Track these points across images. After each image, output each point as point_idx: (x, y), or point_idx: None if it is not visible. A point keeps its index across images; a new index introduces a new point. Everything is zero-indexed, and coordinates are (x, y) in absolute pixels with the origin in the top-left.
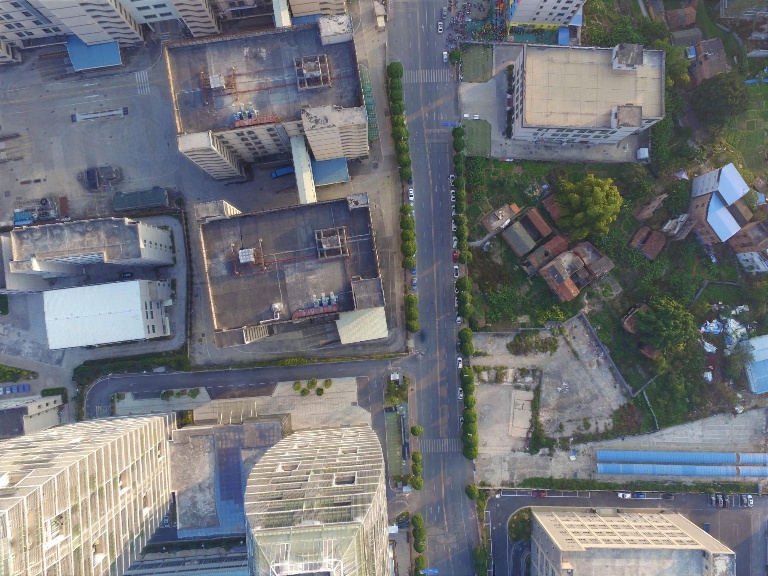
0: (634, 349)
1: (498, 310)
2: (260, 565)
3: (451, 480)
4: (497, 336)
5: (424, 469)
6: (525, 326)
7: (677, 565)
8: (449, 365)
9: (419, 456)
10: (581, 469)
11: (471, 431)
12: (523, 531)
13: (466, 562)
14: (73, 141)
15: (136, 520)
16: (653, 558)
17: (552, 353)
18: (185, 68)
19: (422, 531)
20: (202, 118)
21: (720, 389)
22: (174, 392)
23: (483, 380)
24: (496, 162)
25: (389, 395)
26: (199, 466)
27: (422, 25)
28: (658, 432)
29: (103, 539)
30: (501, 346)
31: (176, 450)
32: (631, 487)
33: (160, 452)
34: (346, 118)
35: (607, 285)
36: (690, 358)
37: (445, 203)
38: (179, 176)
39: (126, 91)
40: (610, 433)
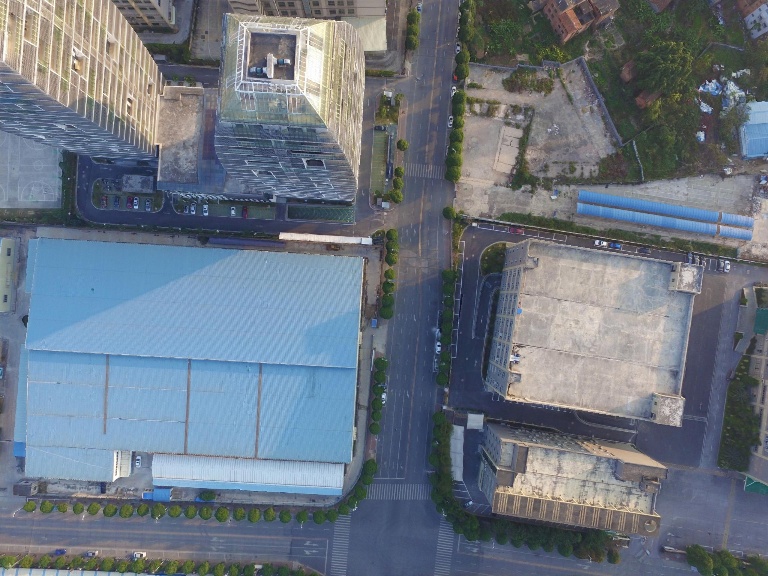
0: (629, 98)
1: (498, 41)
2: (230, 35)
3: (430, 206)
4: (494, 71)
5: (405, 192)
6: (523, 64)
7: (644, 277)
8: (443, 94)
9: (402, 168)
10: (561, 210)
11: (456, 147)
12: (495, 263)
13: (435, 288)
14: None
15: (118, 102)
16: (621, 267)
17: (547, 94)
18: None
19: (395, 243)
20: None
21: (711, 148)
22: (171, 82)
23: (475, 112)
24: None
25: (380, 114)
26: (186, 124)
27: None
28: (643, 185)
29: (84, 62)
30: (497, 81)
31: (166, 106)
32: (609, 234)
33: (150, 95)
34: None
35: (610, 36)
36: (684, 112)
37: None
38: None
39: None
40: (594, 179)
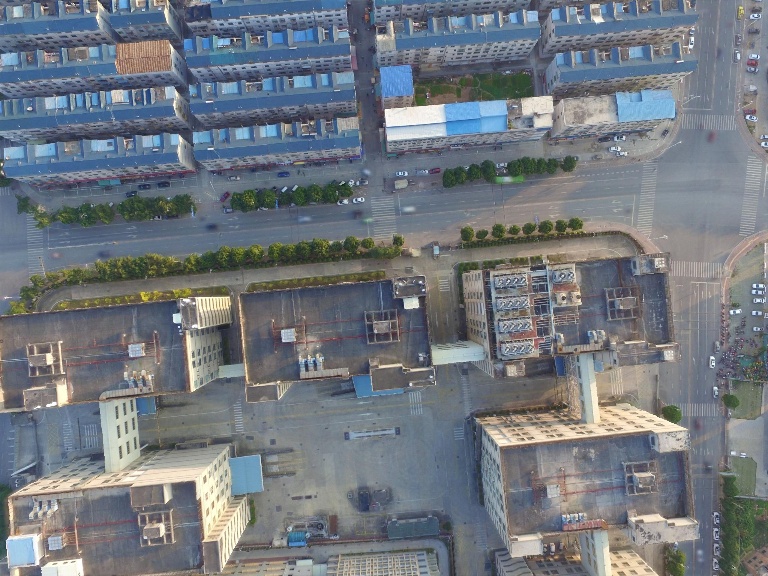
0: None
1: None
2: None
3: None
4: None
5: None
6: None
7: None
8: None
9: None
10: None
11: None
12: None
13: None
14: (345, 459)
15: None
16: None
17: None
18: (515, 466)
19: None
20: (529, 517)
21: None
22: None
23: None
24: (760, 501)
25: None
26: None
27: (693, 358)
28: None
29: None
30: None
31: None
32: None
33: None
34: (679, 535)
35: None
36: None
37: (707, 539)
38: (447, 499)
39: (399, 411)
40: None
